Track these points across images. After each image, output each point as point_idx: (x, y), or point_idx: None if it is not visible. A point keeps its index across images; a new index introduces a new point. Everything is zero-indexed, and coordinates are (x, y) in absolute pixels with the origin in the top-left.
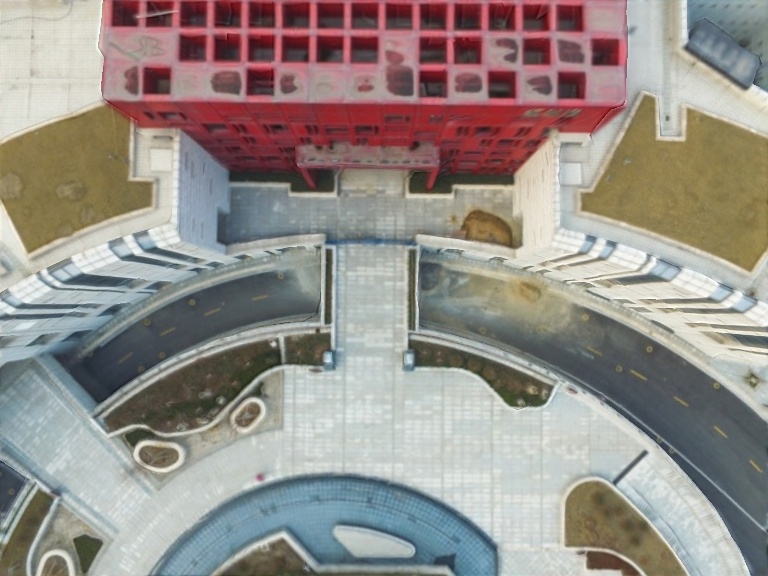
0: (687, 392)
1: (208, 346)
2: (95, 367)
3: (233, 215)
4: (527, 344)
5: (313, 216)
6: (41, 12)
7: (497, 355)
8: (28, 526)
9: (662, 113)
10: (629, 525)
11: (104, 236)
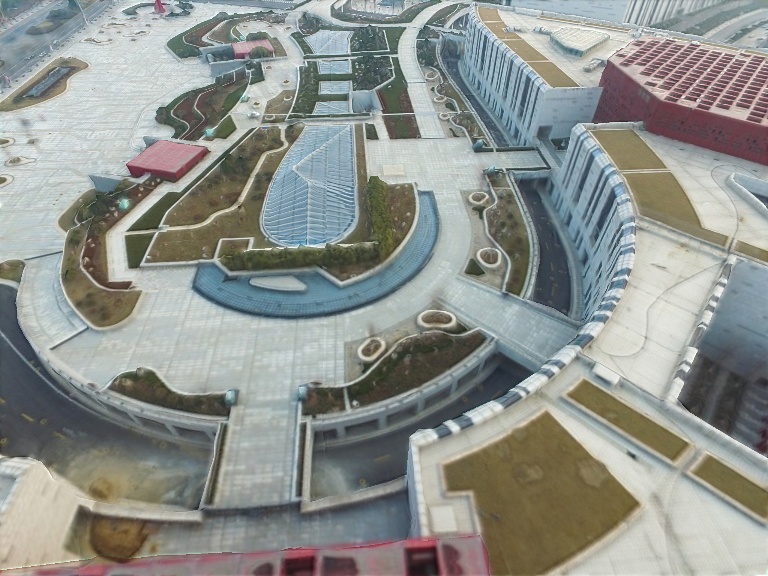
0: None
1: (413, 396)
2: None
3: (405, 527)
4: (123, 436)
5: (316, 536)
6: None
7: (150, 410)
8: (517, 276)
9: None
10: (89, 304)
11: (484, 434)
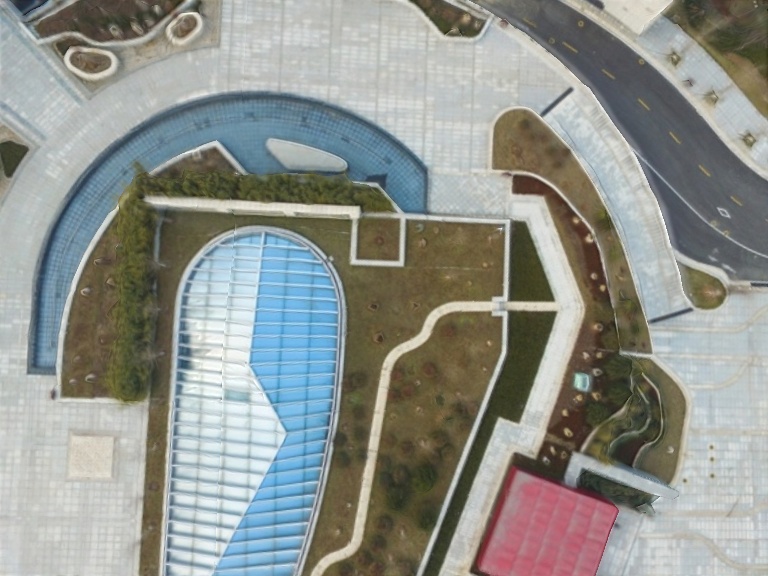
0: (614, 65)
1: None
2: (29, 9)
3: None
4: None
5: None
6: None
7: None
8: None
9: None
10: (553, 151)
11: None
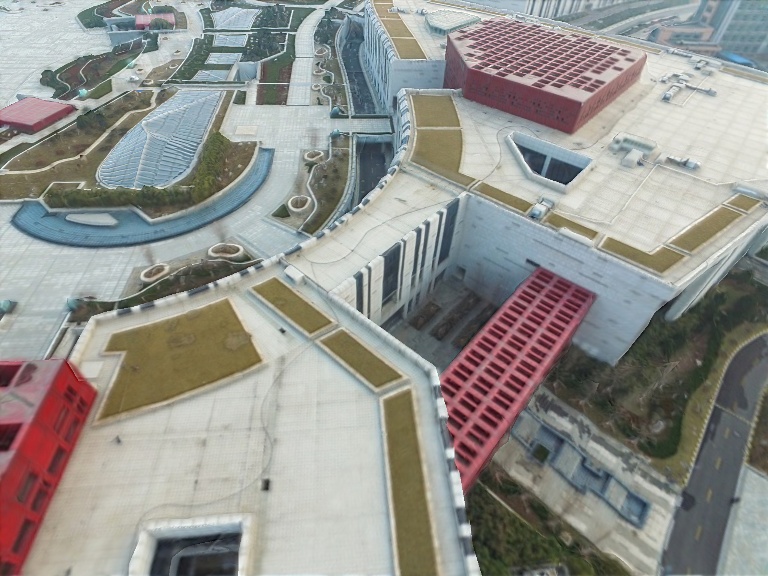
0: None
1: None
2: None
3: None
4: None
5: None
6: (179, 513)
7: None
8: (317, 219)
9: None
10: None
11: (164, 314)
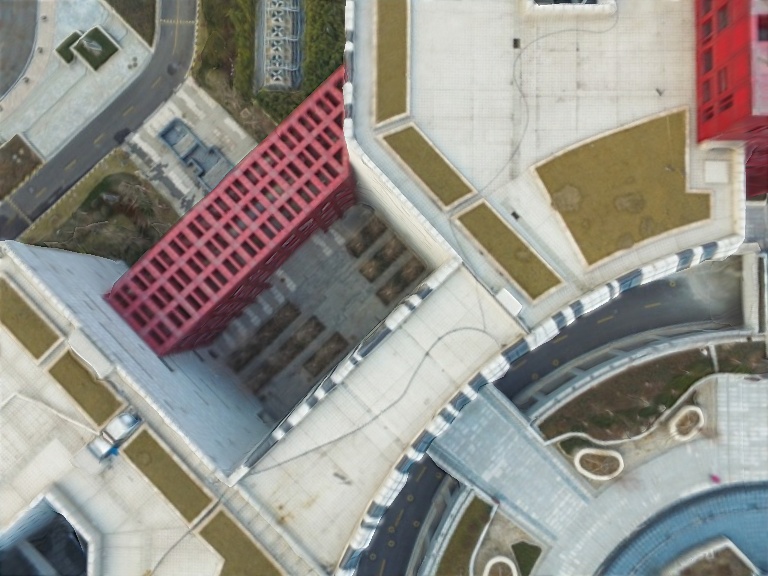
0: None
1: (641, 354)
2: None
3: None
4: None
5: None
6: (586, 25)
7: None
8: (469, 533)
9: None
10: None
11: (660, 248)
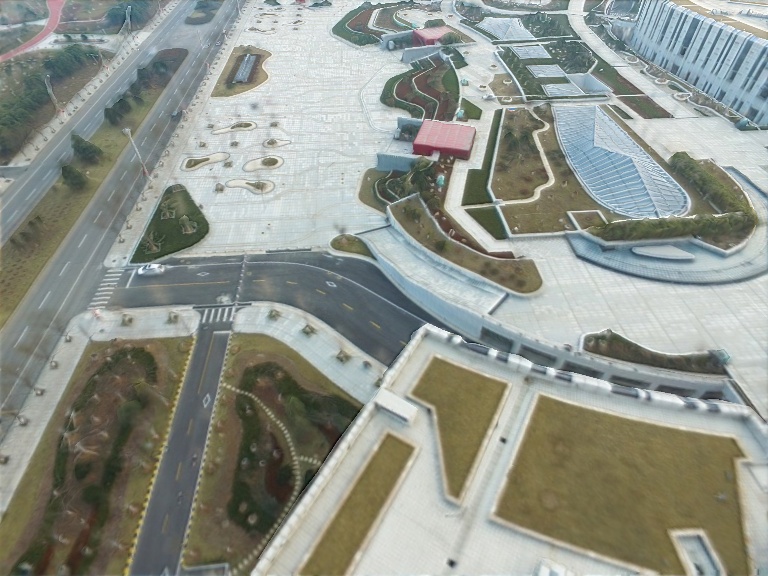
0: None
1: None
2: None
3: None
4: None
5: None
6: None
7: (642, 369)
8: None
9: (707, 575)
10: (493, 272)
11: None
